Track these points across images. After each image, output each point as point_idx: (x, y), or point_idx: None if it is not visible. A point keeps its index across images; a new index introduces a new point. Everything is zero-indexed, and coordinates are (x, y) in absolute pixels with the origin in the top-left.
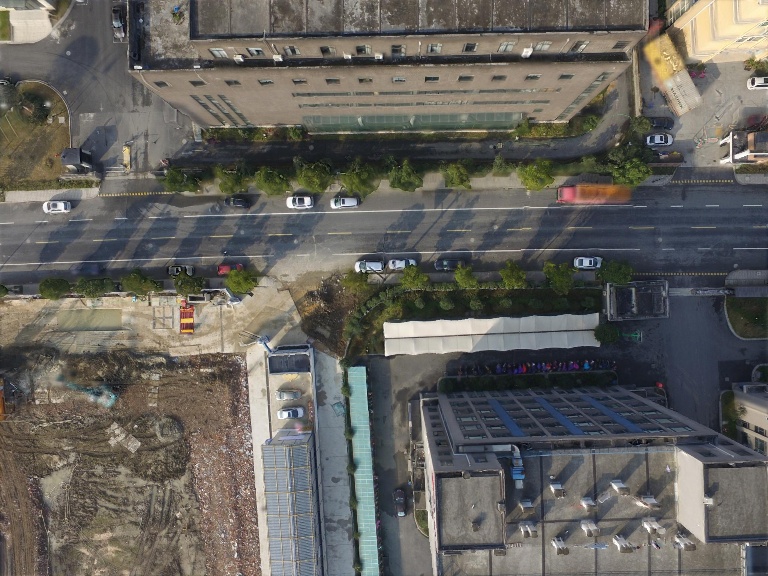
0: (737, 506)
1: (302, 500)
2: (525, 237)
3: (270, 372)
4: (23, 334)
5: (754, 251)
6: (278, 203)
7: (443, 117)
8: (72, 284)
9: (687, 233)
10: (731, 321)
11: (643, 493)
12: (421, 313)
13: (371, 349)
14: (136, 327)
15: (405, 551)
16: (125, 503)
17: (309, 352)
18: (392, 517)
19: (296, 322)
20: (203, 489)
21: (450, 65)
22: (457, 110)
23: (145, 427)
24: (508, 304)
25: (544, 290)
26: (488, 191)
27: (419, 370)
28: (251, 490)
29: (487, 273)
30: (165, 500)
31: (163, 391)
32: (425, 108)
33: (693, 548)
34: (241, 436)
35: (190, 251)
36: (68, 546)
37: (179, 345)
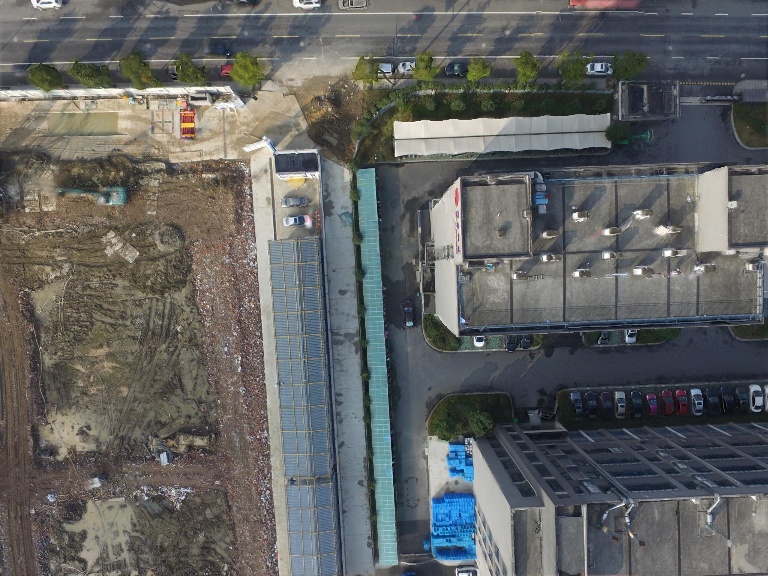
0: (759, 213)
1: (310, 296)
2: (537, 43)
3: (276, 171)
4: (11, 138)
5: (761, 61)
6: (284, 3)
7: None
8: (64, 86)
9: (696, 42)
10: (737, 130)
11: (664, 224)
12: (431, 119)
13: (380, 157)
14: (133, 132)
15: (413, 364)
16: (123, 317)
17: (317, 150)
18: (400, 330)
19: (302, 128)
20: (205, 301)
21: None
22: None
23: (144, 236)
24: (520, 104)
25: (555, 95)
26: None
27: (428, 179)
28: (255, 303)
29: (498, 80)
30: (165, 313)
31: (163, 198)
32: None
33: (713, 269)
34: (245, 246)
35: (190, 52)
36: (62, 363)
37: (179, 151)
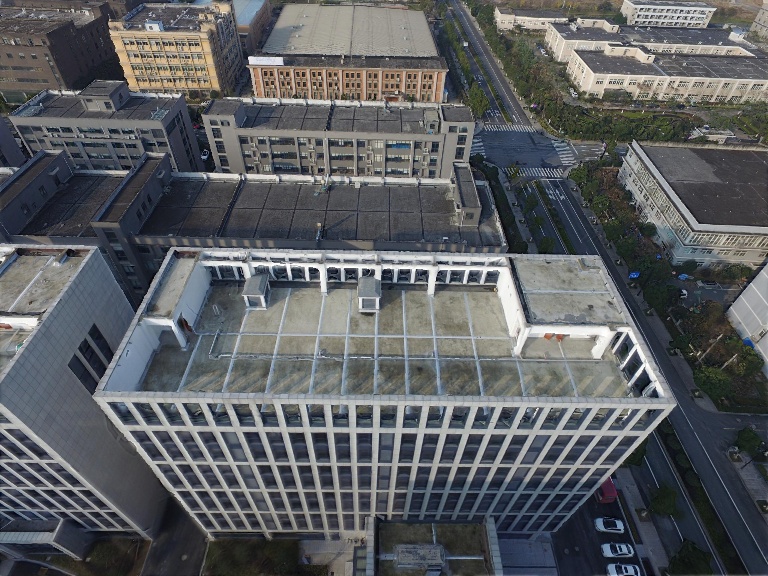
0: None
1: None
2: None
3: None
4: None
5: None
6: None
7: (10, 90)
8: None
9: None
10: None
11: None
12: None
13: None
14: None
15: None
16: None
17: None
18: None
19: None
20: None
21: None
22: (16, 87)
23: None
24: None
25: None
26: None
27: None
28: None
29: None
30: None
31: None
32: (1, 84)
33: None
34: None
35: None
36: None
37: None
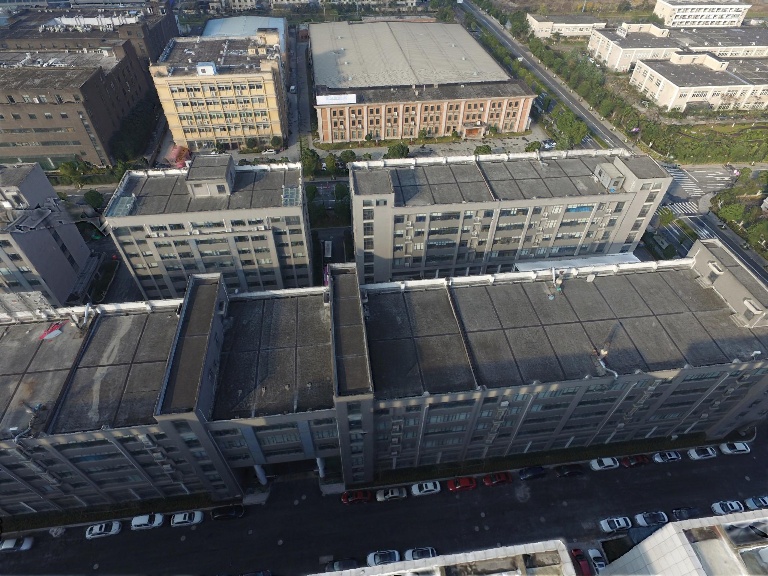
0: None
1: None
2: None
3: None
4: None
5: None
6: None
7: (32, 156)
8: None
9: None
10: None
11: None
12: None
13: None
14: None
15: None
16: None
17: None
18: None
19: None
20: None
21: (0, 104)
22: (38, 152)
23: None
24: None
25: None
26: None
27: None
28: None
29: None
30: None
31: None
32: (19, 149)
33: None
34: None
35: None
36: None
37: None
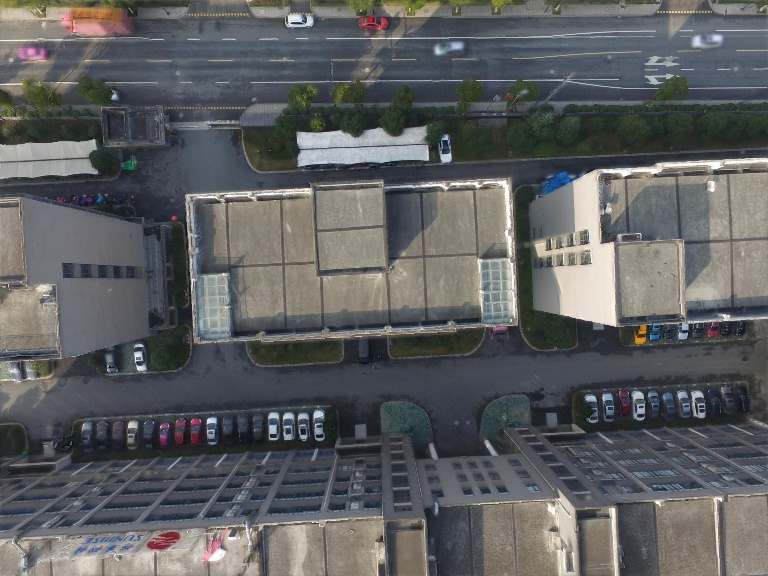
0: None
1: None
2: (41, 70)
3: None
4: None
5: (271, 85)
6: None
7: None
8: None
9: (204, 67)
10: (248, 154)
11: None
12: None
13: None
14: None
15: None
16: None
17: None
18: None
19: None
20: None
21: None
22: None
23: None
24: (4, 131)
25: (53, 121)
26: (2, 23)
27: None
28: None
29: (2, 107)
30: None
31: None
32: None
33: None
34: None
35: None
36: None
37: None
